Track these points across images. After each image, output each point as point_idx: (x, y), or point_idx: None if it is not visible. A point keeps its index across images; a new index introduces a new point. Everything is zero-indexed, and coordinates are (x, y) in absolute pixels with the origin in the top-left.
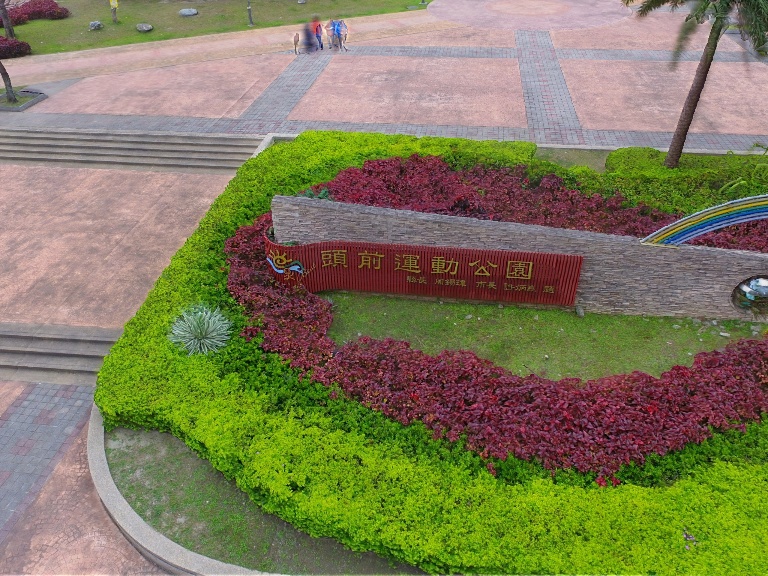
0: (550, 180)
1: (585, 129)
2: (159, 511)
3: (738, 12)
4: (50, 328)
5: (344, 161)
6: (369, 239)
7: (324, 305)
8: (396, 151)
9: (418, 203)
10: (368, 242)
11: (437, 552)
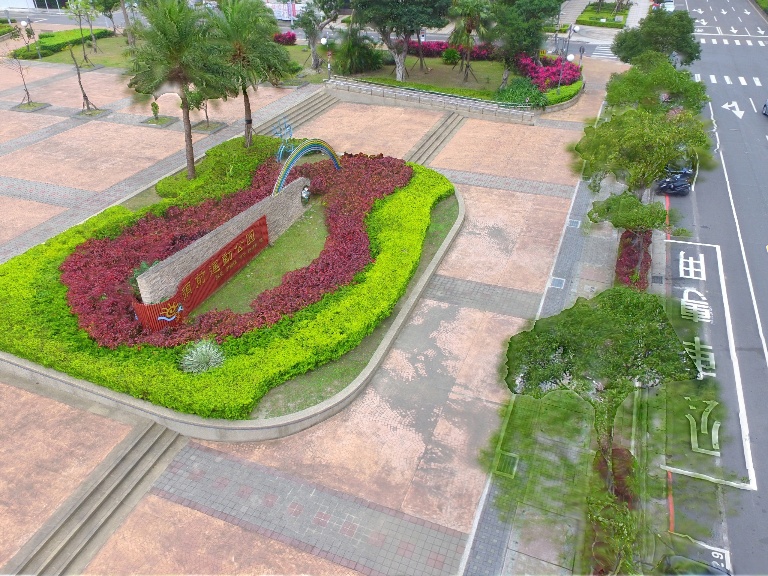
0: (175, 209)
1: (102, 191)
2: (321, 396)
3: (206, 87)
4: (94, 476)
5: (40, 279)
6: (193, 268)
7: (214, 312)
8: (57, 255)
9: (144, 258)
10: (195, 269)
11: (388, 303)
